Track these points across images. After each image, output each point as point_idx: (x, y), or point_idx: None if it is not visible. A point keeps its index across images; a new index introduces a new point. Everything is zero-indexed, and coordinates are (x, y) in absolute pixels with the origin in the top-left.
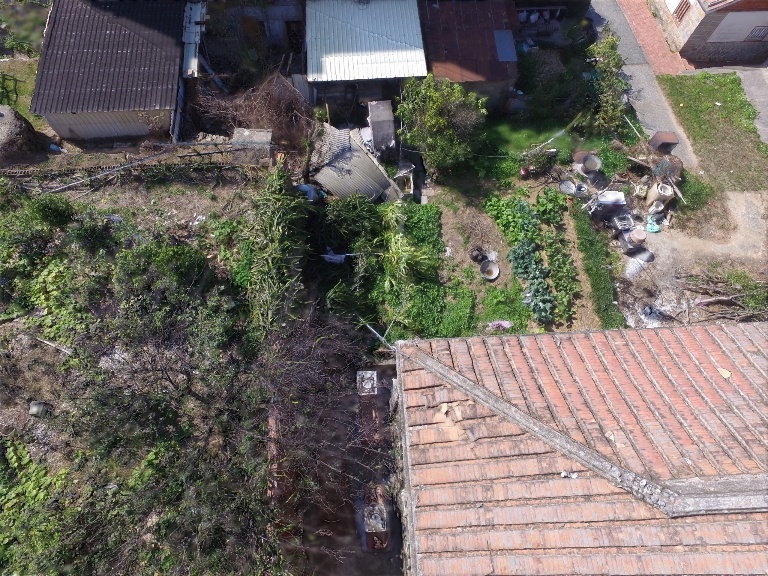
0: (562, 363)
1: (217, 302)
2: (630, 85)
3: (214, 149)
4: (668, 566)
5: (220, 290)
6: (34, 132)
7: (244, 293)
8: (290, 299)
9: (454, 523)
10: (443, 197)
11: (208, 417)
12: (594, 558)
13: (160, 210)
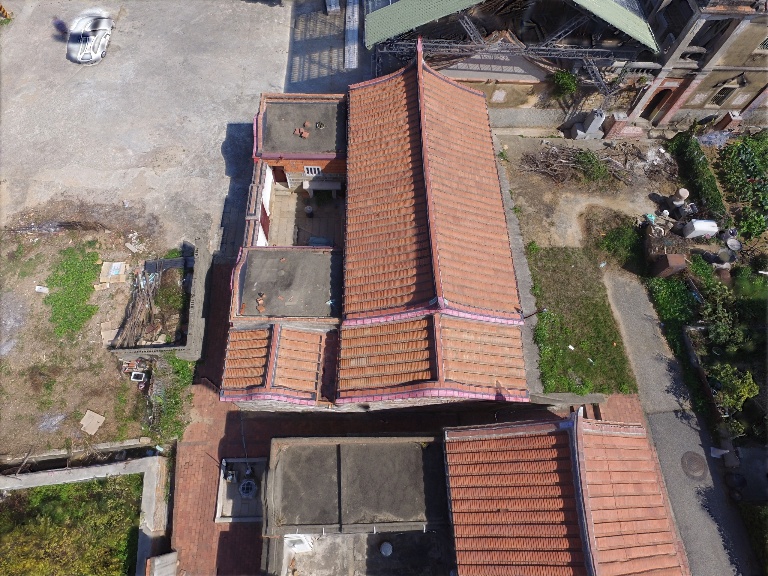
0: None
1: None
2: (712, 327)
3: None
4: None
5: None
6: None
7: None
8: None
9: None
10: None
11: None
12: None
13: None
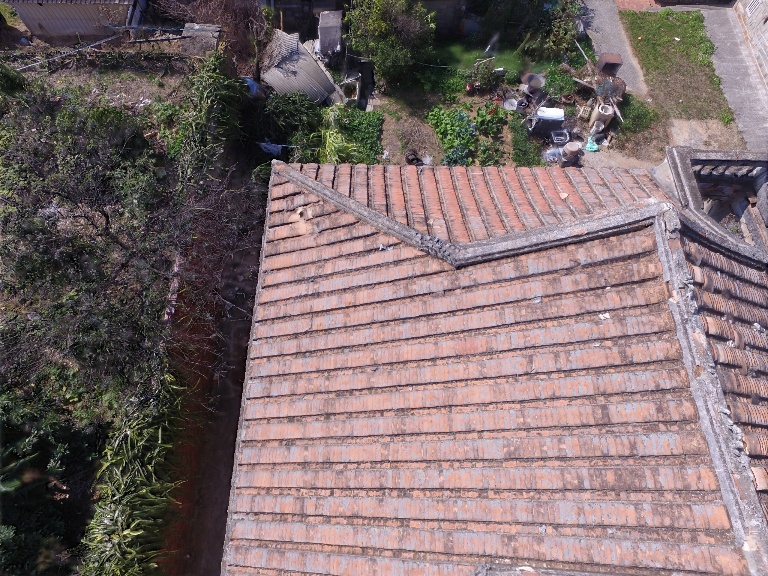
0: (416, 182)
1: (145, 163)
2: (583, 11)
3: (168, 44)
4: (445, 305)
5: (149, 153)
6: (6, 24)
7: (177, 166)
8: (210, 161)
9: (288, 295)
10: (388, 107)
11: (129, 266)
12: (390, 307)
13: (105, 85)
